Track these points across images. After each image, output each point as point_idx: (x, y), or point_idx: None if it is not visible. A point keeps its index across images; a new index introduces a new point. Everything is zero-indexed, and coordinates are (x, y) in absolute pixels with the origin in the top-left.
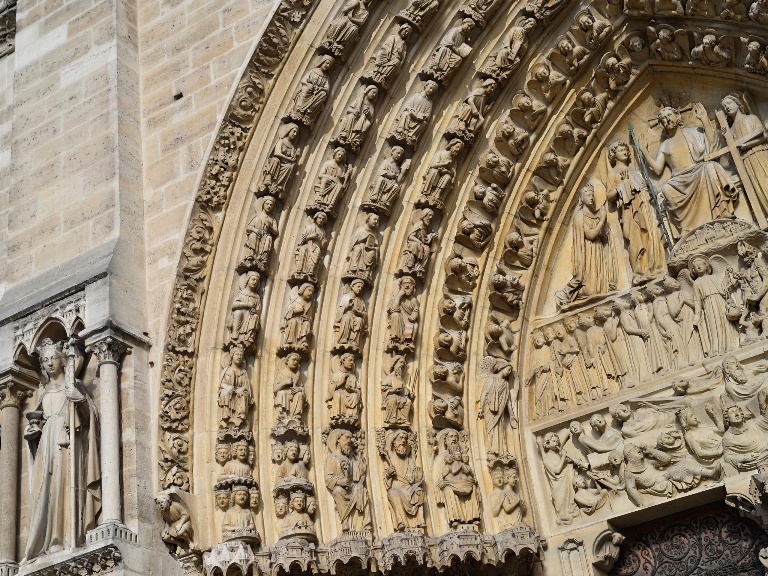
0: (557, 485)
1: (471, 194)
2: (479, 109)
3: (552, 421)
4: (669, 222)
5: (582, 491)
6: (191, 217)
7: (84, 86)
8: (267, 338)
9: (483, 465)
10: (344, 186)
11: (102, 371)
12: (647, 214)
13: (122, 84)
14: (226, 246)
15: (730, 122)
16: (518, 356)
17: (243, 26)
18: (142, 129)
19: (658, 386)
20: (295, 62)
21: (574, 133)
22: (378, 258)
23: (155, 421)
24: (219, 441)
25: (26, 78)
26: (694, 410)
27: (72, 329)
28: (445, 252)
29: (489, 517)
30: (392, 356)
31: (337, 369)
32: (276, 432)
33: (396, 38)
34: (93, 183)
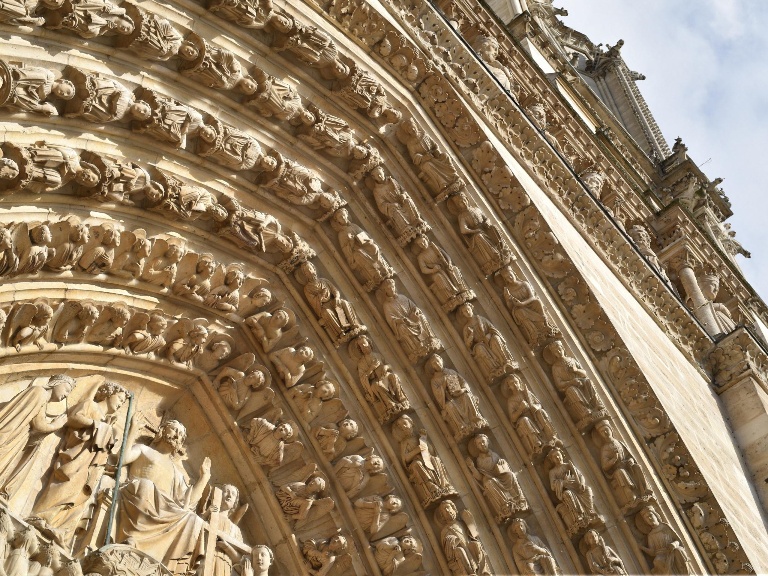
0: None
1: (32, 223)
2: None
3: None
4: (115, 515)
5: None
6: None
7: None
8: None
9: None
10: None
11: None
12: (97, 480)
13: None
14: None
15: None
16: None
17: None
18: None
19: None
20: None
21: None
22: None
23: None
24: None
25: None
26: None
27: None
28: None
29: None
30: None
31: None
32: None
33: None
34: None
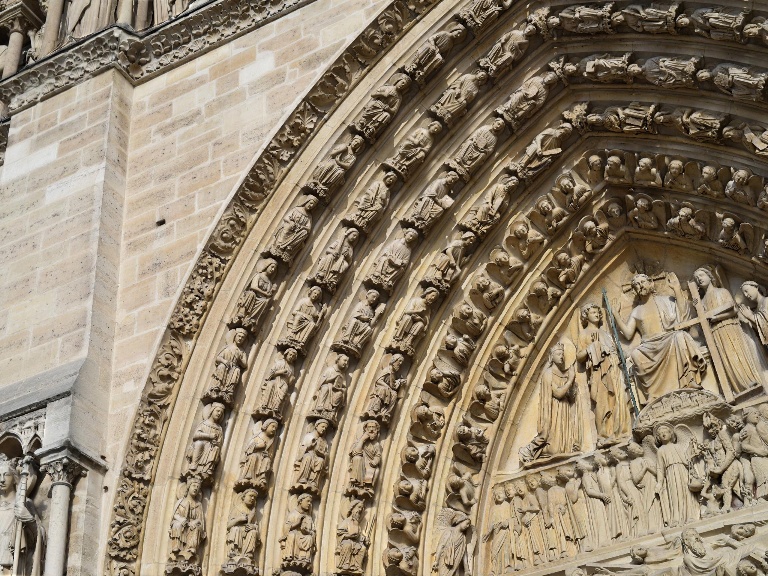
0: None
1: (442, 343)
2: (457, 260)
3: None
4: (636, 387)
5: None
6: (161, 343)
7: (68, 205)
8: (226, 471)
9: None
10: (317, 325)
11: (54, 492)
12: (615, 377)
13: (106, 206)
14: (193, 375)
15: (702, 294)
16: (477, 510)
17: (232, 160)
18: (121, 252)
19: (616, 552)
20: (279, 199)
21: (548, 291)
22: (345, 399)
23: (103, 548)
24: (166, 574)
25: (12, 192)
26: None
27: (29, 446)
28: (412, 399)
29: None
30: (350, 500)
31: (294, 509)
32: (226, 569)
33: (381, 184)
34: (67, 301)
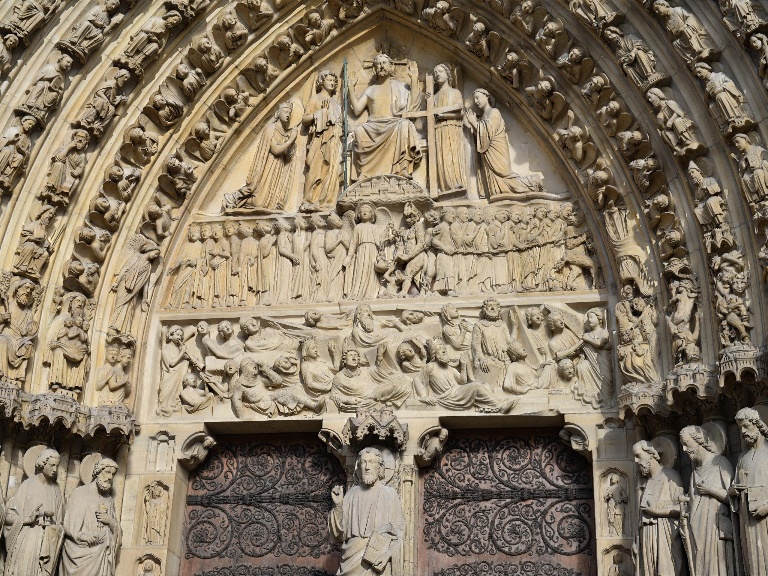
0: (168, 377)
1: (173, 71)
2: None
3: (182, 315)
4: (352, 162)
5: (190, 389)
6: None
7: None
8: None
9: (101, 338)
10: (46, 17)
11: None
12: (334, 148)
13: None
14: None
15: (436, 89)
16: (169, 243)
17: None
18: None
19: (292, 312)
20: None
21: (292, 47)
22: (59, 102)
23: None
24: None
25: None
26: (318, 343)
27: None
28: (129, 119)
29: (91, 389)
30: (43, 204)
31: None
32: None
33: None
34: None
